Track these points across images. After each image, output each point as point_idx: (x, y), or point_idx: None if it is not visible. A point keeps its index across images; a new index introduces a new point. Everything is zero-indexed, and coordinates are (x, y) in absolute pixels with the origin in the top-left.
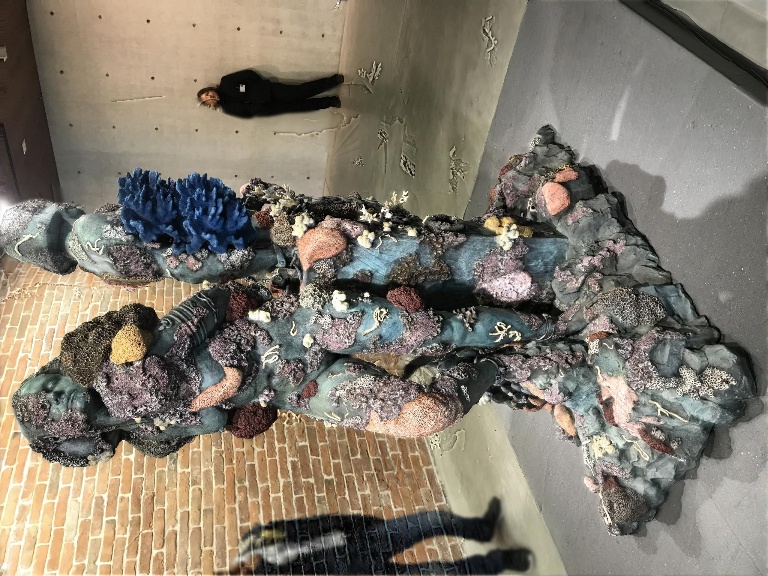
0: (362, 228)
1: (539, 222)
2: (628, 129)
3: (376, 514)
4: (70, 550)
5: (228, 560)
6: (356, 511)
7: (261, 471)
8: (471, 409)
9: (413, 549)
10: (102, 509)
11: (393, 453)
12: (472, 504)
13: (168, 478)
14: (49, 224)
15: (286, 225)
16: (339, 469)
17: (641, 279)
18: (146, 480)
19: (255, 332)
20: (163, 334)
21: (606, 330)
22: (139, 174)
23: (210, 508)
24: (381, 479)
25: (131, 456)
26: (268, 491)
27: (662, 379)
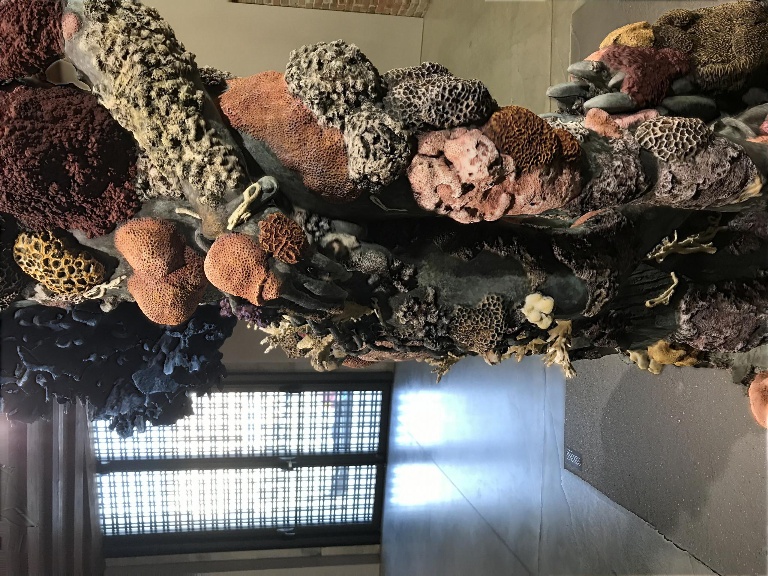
0: None
1: None
2: None
3: None
4: None
5: None
6: None
7: None
8: None
9: None
10: None
11: None
12: None
13: None
14: None
15: None
16: None
17: None
18: None
19: None
20: None
21: None
22: None
23: None
24: None
25: None
26: None
27: None
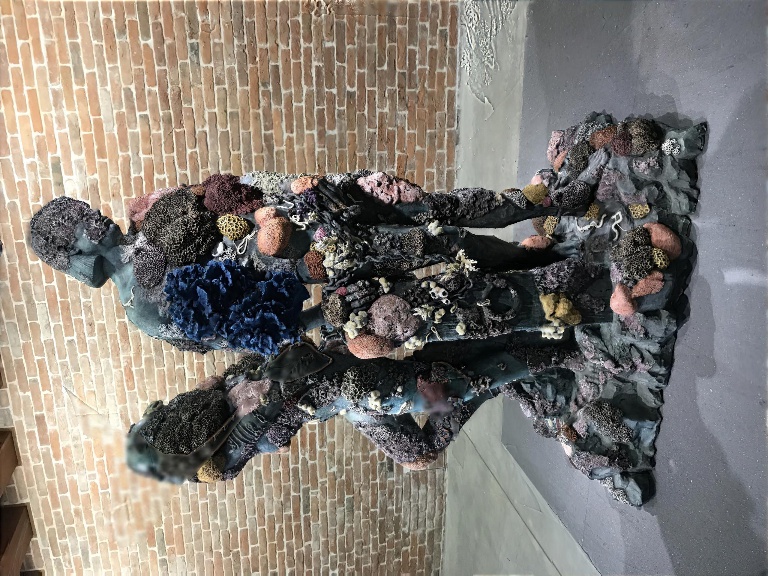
0: (412, 330)
1: (605, 269)
2: (738, 299)
3: (389, 134)
4: (113, 141)
5: (254, 165)
6: (372, 130)
7: (285, 75)
8: (506, 109)
9: (414, 170)
10: (133, 101)
11: (421, 68)
12: (476, 163)
13: (192, 72)
14: (92, 278)
15: (338, 325)
16: (363, 80)
17: (640, 393)
18: (170, 73)
19: (302, 416)
20: (233, 455)
21: (579, 433)
22: (186, 288)
23: (236, 111)
24: (402, 97)
25: (150, 42)
26: (291, 98)
27: (591, 479)
